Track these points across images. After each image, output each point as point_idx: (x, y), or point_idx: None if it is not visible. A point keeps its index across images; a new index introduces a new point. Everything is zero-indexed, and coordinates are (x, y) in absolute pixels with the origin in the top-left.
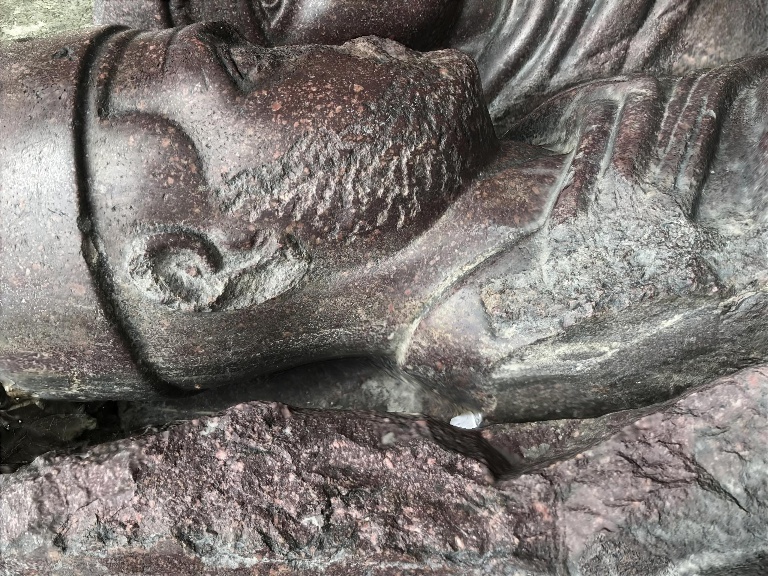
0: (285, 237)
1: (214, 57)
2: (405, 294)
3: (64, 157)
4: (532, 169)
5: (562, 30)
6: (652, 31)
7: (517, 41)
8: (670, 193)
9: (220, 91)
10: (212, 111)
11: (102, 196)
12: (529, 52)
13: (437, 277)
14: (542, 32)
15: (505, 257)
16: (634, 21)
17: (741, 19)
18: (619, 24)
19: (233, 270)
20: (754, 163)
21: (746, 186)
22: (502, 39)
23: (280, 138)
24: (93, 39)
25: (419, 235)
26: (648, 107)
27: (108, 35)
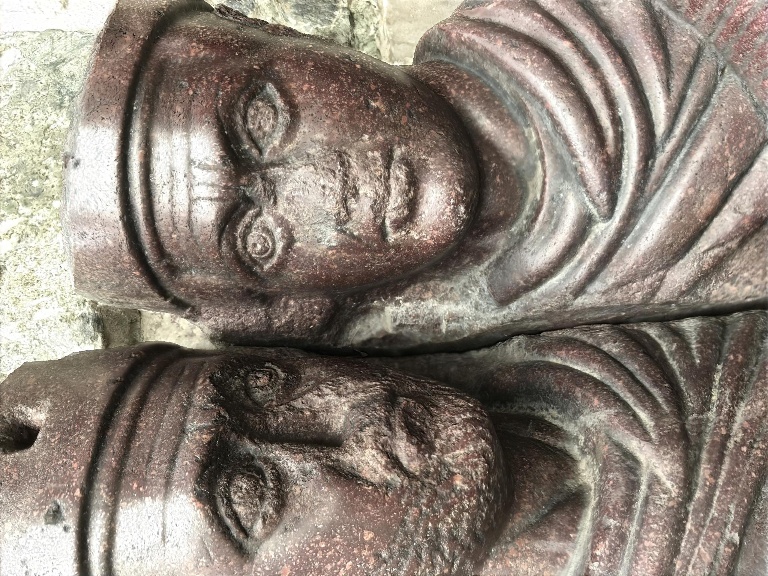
0: None
1: (215, 523)
2: None
3: None
4: (545, 542)
5: (592, 260)
6: (694, 266)
7: (540, 264)
8: None
9: (226, 563)
10: None
11: None
12: (553, 273)
13: None
14: (569, 256)
15: None
16: (675, 257)
17: None
18: (657, 261)
19: None
20: None
21: None
22: (524, 254)
23: None
24: (83, 484)
25: None
26: (670, 522)
27: (97, 459)
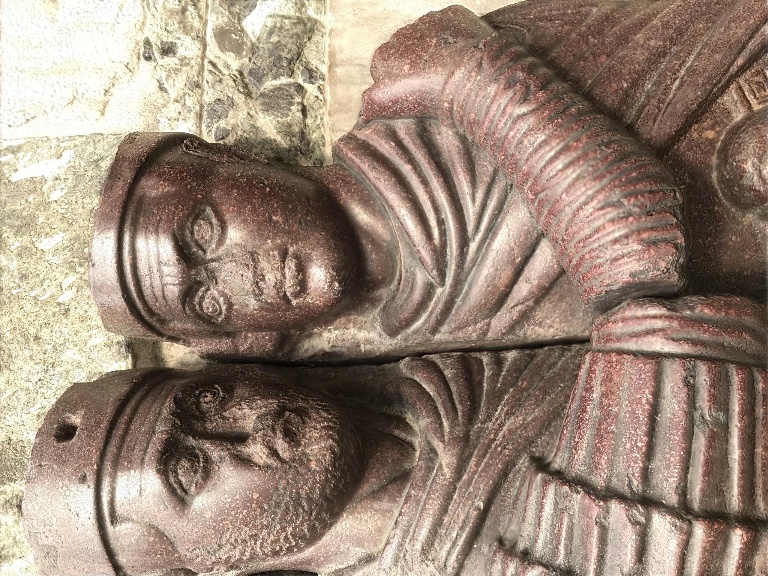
0: (229, 568)
1: (168, 486)
2: (308, 568)
3: (100, 552)
4: (380, 503)
5: (437, 312)
6: (507, 317)
7: (405, 313)
8: (440, 571)
9: (175, 509)
10: (173, 520)
11: (125, 563)
12: (416, 319)
13: (324, 566)
14: (423, 308)
15: (355, 575)
16: (491, 311)
17: (580, 306)
18: (479, 314)
19: (206, 574)
20: (489, 563)
21: (484, 573)
22: (396, 306)
23: (213, 533)
24: (98, 462)
25: (310, 547)
26: (442, 494)
27: (106, 448)
